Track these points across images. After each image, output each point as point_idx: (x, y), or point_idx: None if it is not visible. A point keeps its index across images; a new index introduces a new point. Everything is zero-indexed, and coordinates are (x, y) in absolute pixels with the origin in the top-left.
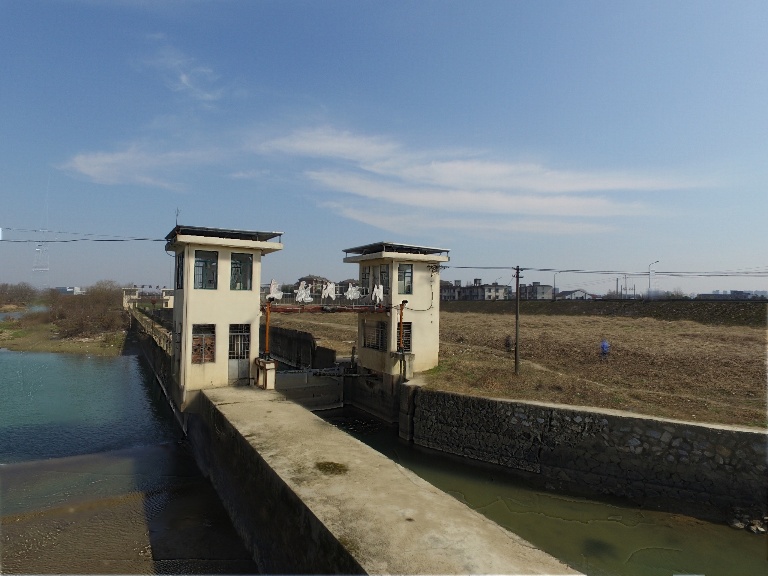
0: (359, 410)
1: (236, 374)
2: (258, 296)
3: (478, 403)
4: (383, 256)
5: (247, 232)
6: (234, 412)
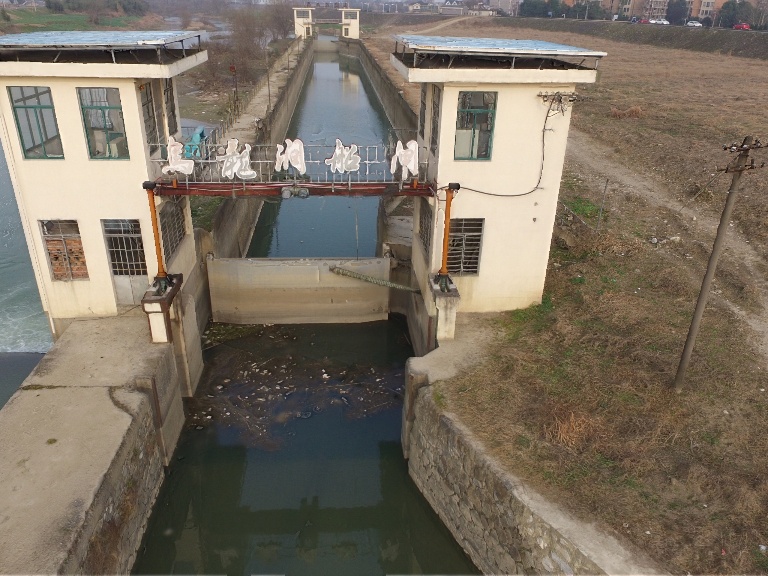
0: (404, 336)
1: (130, 298)
2: (144, 170)
3: (494, 485)
4: (410, 80)
5: (86, 46)
6: (6, 427)
